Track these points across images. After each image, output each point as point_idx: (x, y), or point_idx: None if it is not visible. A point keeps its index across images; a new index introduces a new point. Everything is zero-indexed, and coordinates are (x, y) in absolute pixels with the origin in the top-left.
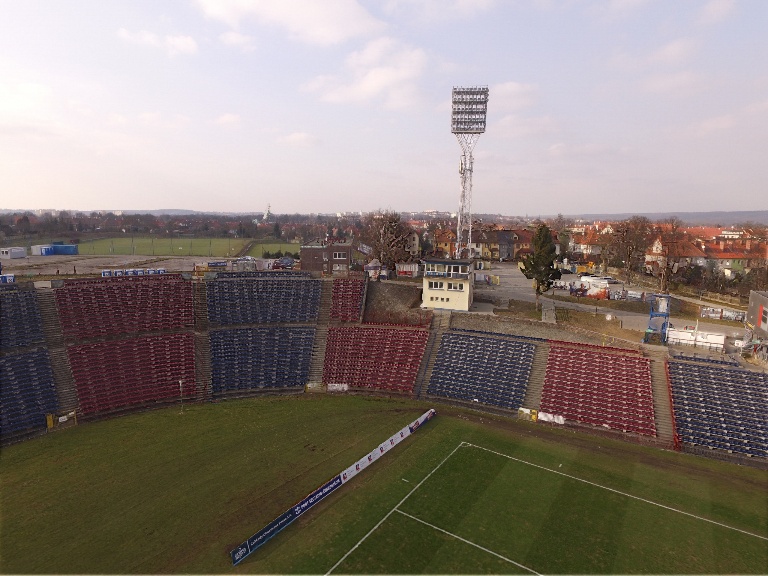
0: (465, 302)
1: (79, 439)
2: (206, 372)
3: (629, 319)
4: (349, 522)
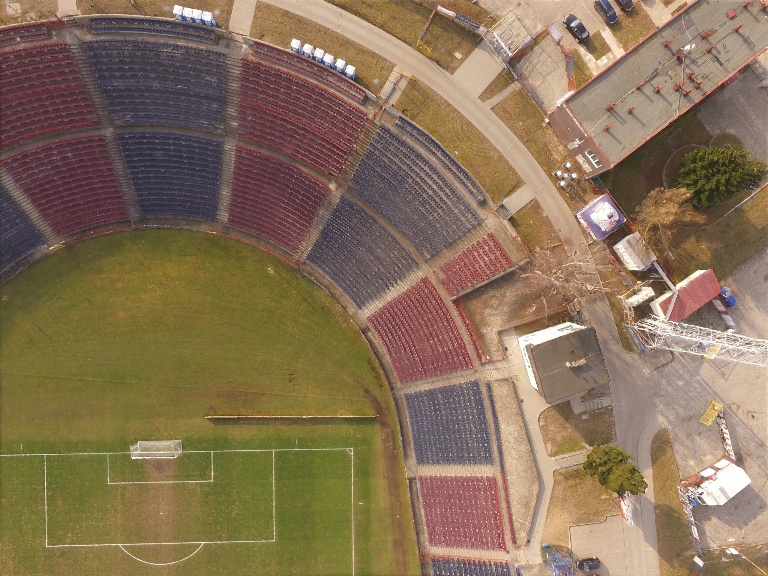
0: (534, 385)
1: (213, 254)
2: (313, 237)
3: (617, 527)
4: (253, 439)
